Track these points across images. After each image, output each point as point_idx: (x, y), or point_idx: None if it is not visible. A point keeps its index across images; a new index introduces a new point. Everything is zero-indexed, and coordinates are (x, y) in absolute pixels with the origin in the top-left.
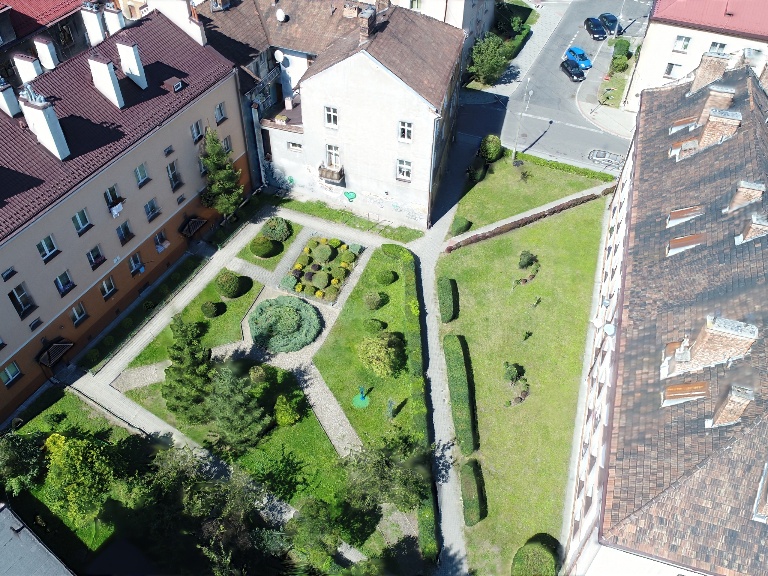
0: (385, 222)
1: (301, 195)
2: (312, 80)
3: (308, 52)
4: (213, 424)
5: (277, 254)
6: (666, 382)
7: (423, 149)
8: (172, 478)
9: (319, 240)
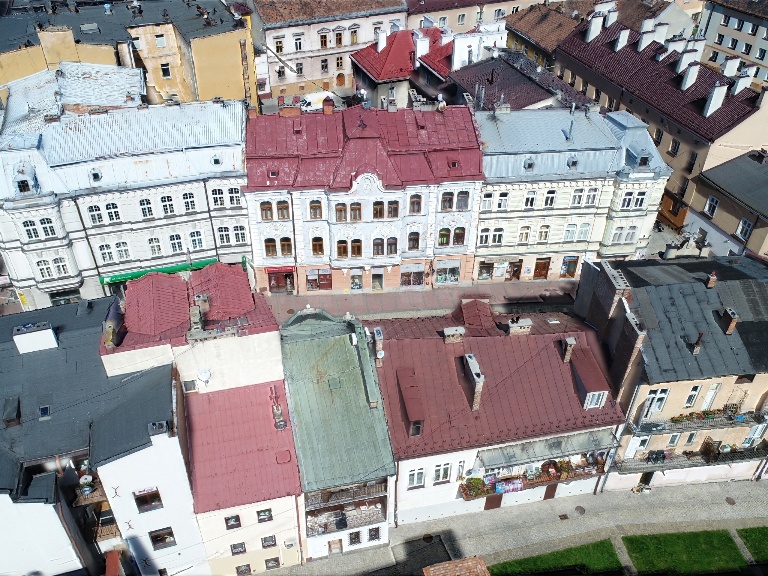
0: None
1: None
2: None
3: None
4: None
5: None
6: None
7: None
8: None
9: None
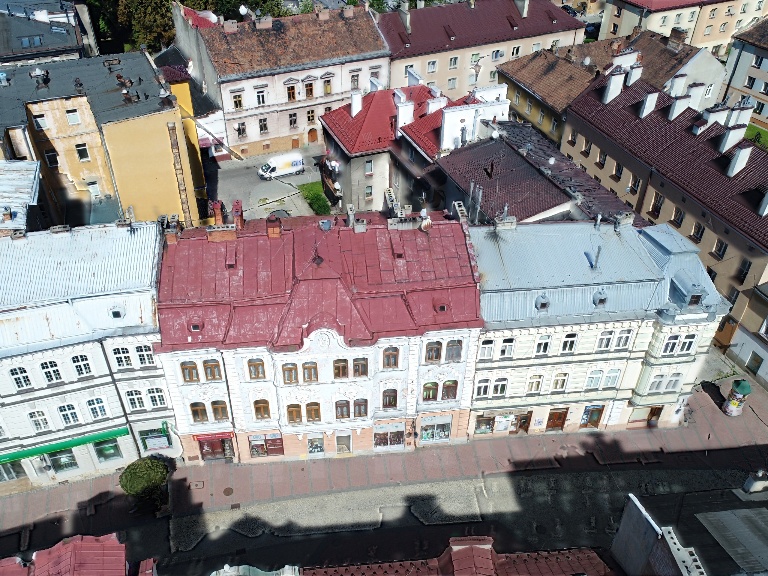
0: None
1: None
2: None
3: None
4: None
5: None
6: None
7: None
8: None
9: None
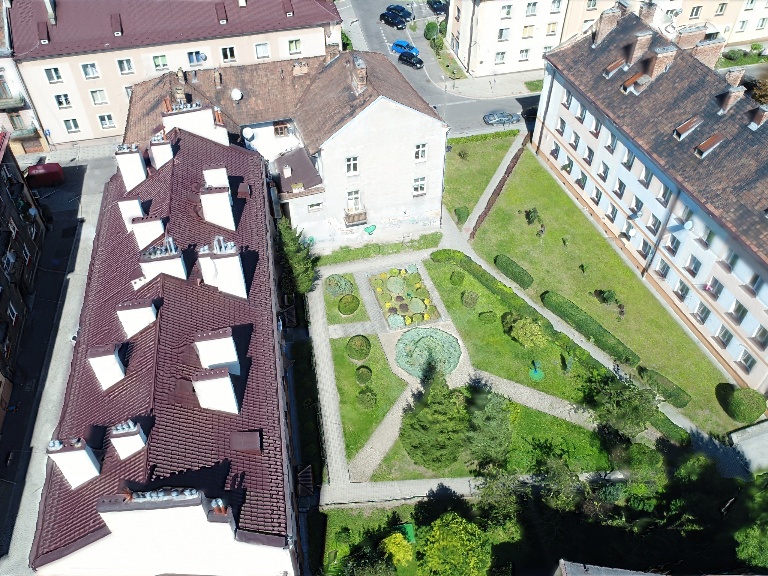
0: (406, 238)
1: (322, 250)
2: (334, 139)
3: (280, 119)
4: (462, 457)
5: None
6: None
7: (437, 161)
8: (513, 502)
9: (376, 277)
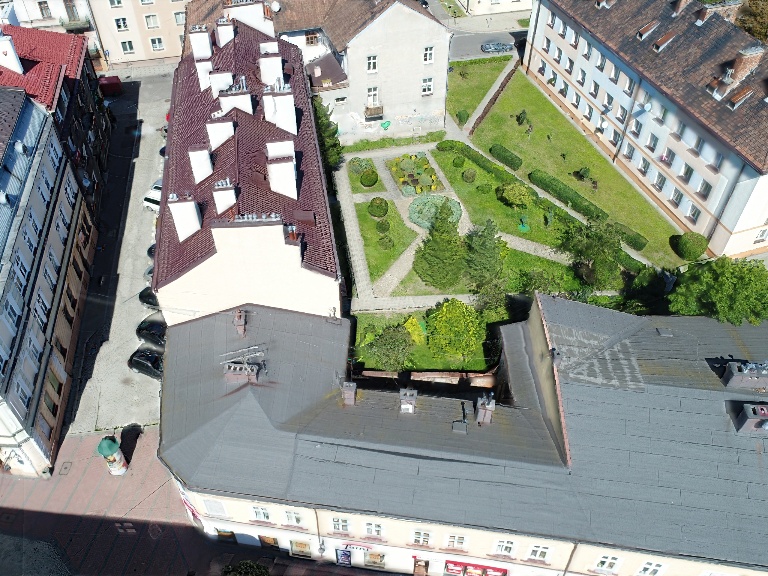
0: (416, 135)
1: (345, 142)
2: (358, 38)
3: (312, 28)
4: (463, 281)
5: (377, 181)
6: (724, 100)
7: (442, 64)
8: (504, 299)
9: (391, 161)
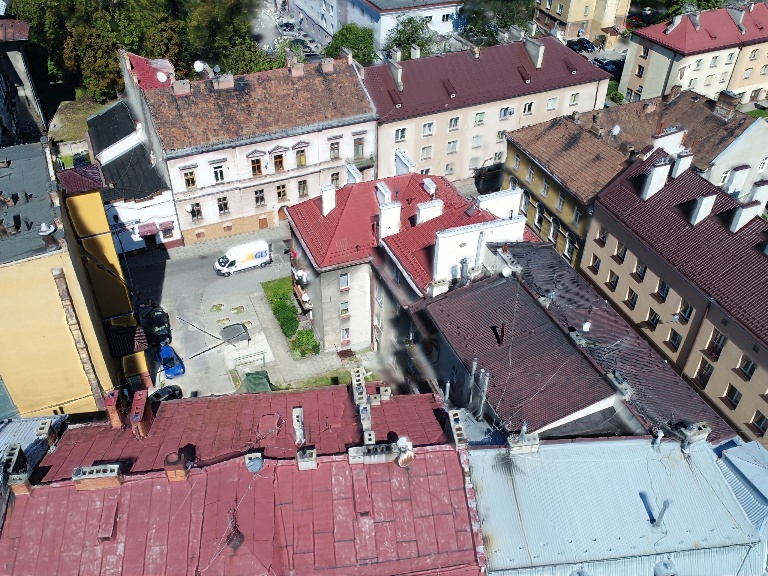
0: None
1: None
2: (725, 155)
3: None
4: None
5: None
6: None
7: None
8: None
9: None
